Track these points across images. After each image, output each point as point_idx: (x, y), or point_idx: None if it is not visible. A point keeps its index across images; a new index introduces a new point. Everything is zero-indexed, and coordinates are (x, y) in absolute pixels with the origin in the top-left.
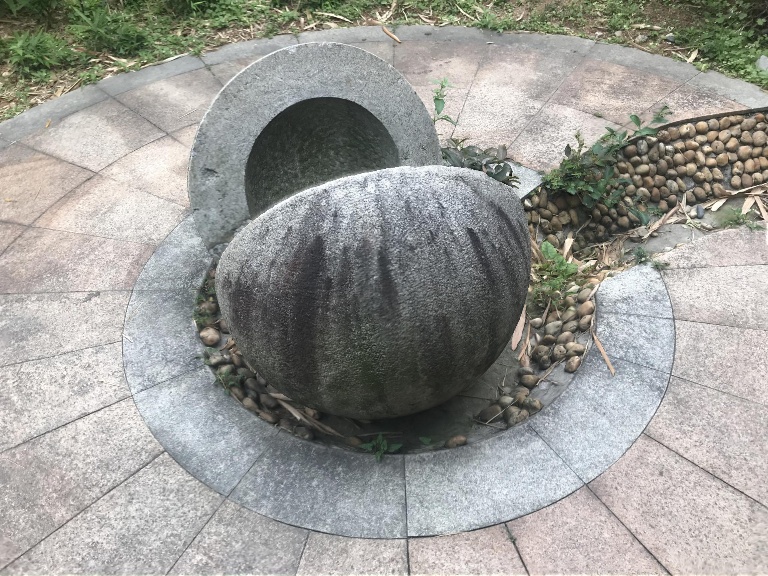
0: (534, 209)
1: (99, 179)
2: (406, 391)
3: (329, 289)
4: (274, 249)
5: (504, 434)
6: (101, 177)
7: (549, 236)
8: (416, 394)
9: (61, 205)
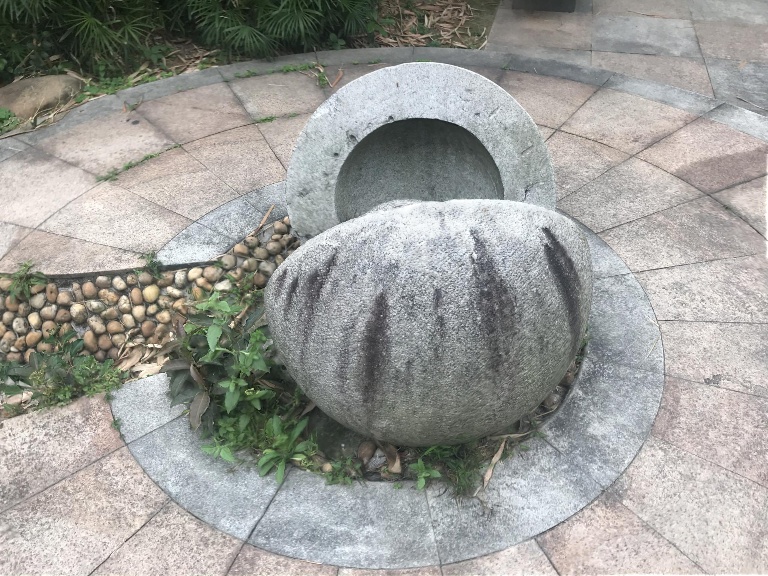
0: None
1: None
2: None
3: None
4: None
5: None
6: None
7: None
8: None
9: None
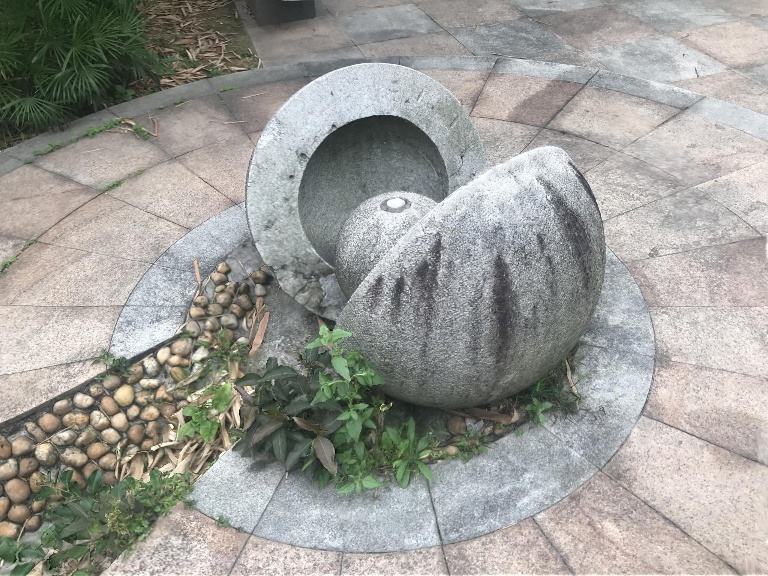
0: None
1: None
2: None
3: None
4: None
5: None
6: None
7: None
8: None
9: None
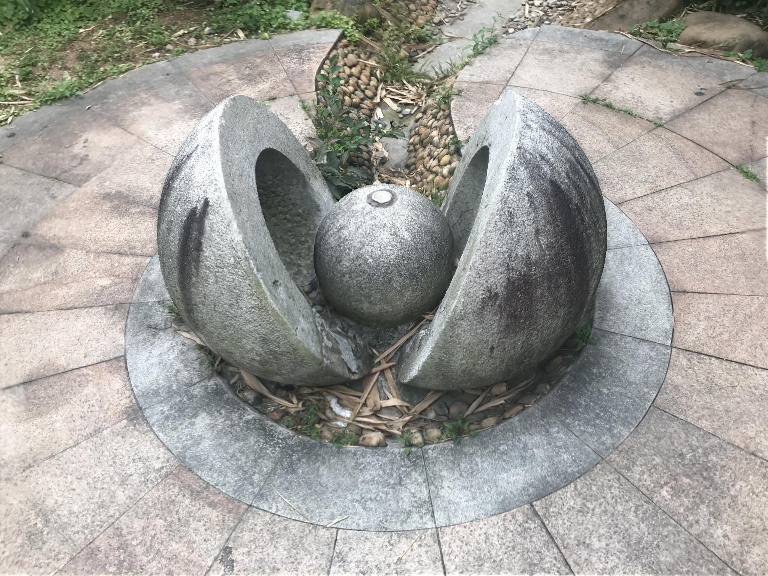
0: None
1: None
2: None
3: (580, 212)
4: (529, 221)
5: None
6: None
7: None
8: None
9: None
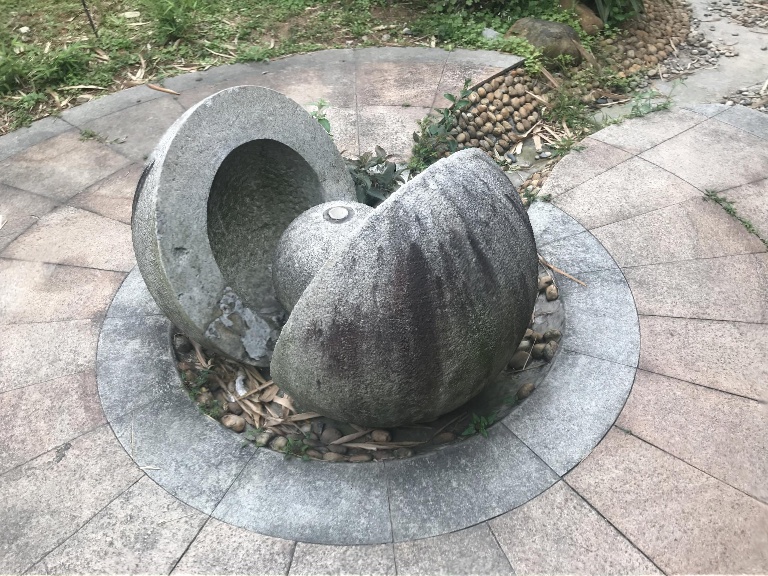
0: None
1: None
2: (505, 356)
3: (441, 287)
4: (371, 274)
5: (555, 365)
6: None
7: None
8: (508, 357)
9: None
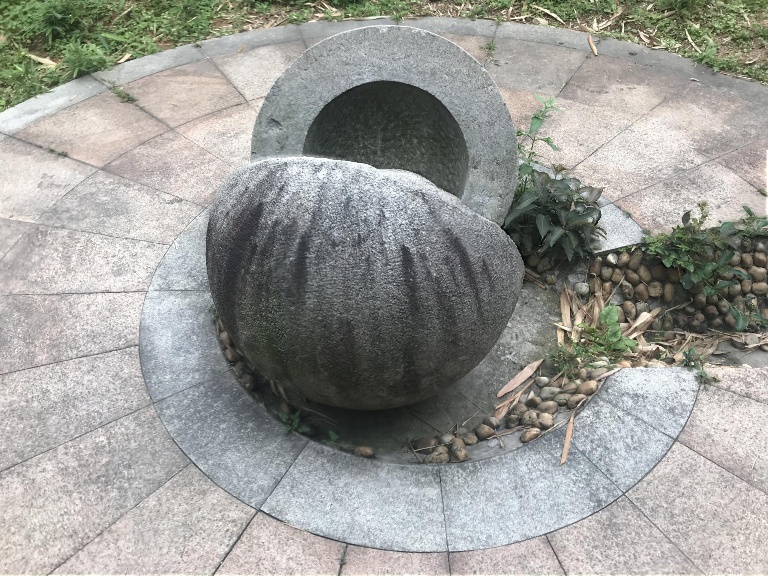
0: (619, 267)
1: (245, 107)
2: (309, 379)
3: (254, 254)
4: (233, 202)
5: (409, 466)
6: (248, 106)
7: (626, 302)
8: (320, 386)
9: (204, 120)
